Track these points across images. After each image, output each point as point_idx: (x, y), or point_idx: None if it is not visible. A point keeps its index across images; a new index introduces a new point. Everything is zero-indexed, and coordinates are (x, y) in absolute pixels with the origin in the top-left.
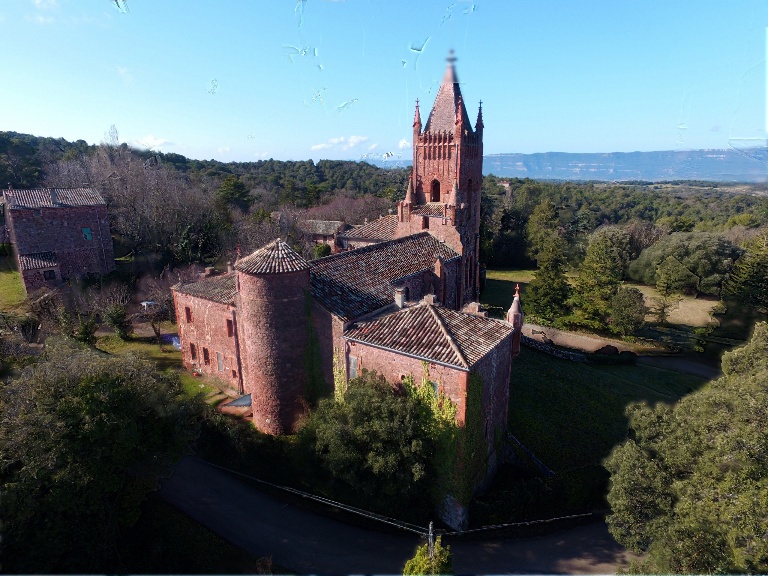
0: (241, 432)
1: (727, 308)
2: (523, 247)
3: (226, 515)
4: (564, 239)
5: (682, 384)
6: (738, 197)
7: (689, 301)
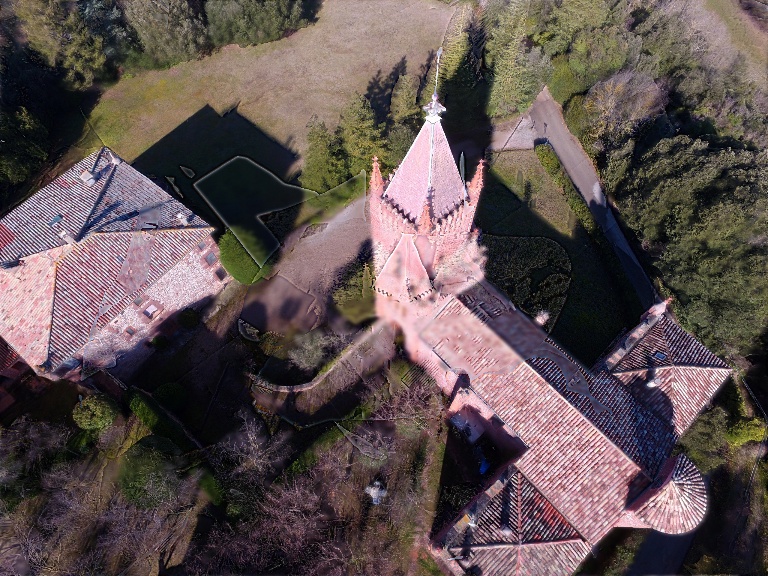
0: (643, 533)
1: (447, 94)
2: (52, 80)
3: (675, 542)
4: (94, 35)
5: (496, 184)
6: (454, 4)
7: (293, 47)
